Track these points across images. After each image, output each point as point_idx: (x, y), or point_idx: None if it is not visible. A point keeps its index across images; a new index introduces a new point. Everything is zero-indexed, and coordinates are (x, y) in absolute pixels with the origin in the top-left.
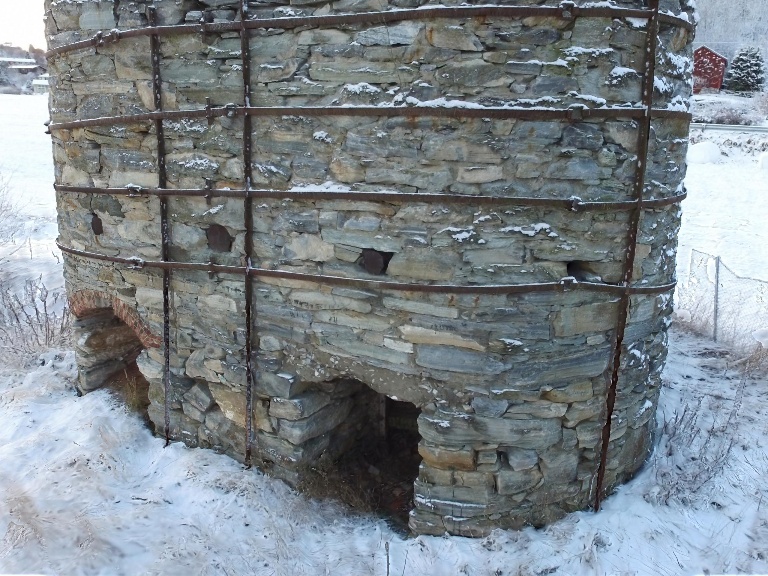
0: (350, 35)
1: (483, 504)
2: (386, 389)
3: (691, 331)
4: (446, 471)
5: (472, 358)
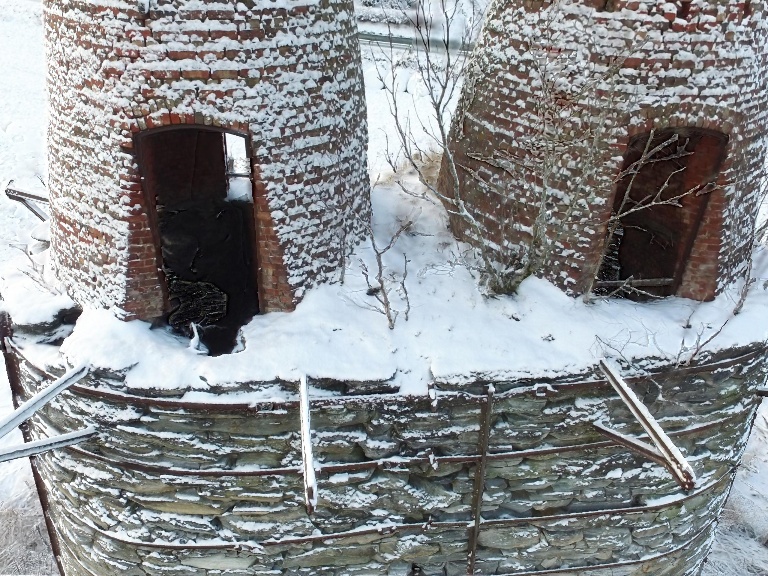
0: (576, 574)
1: None
2: None
3: None
4: None
5: None
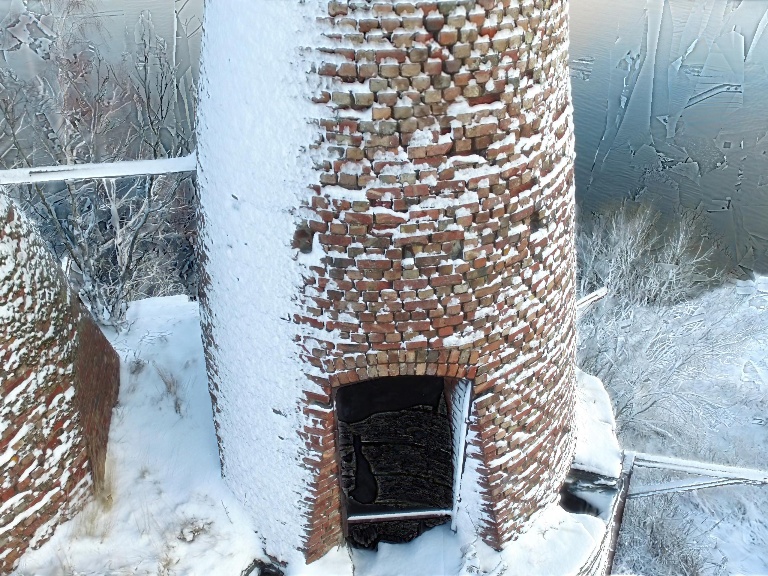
0: None
1: None
2: None
3: None
4: None
5: None
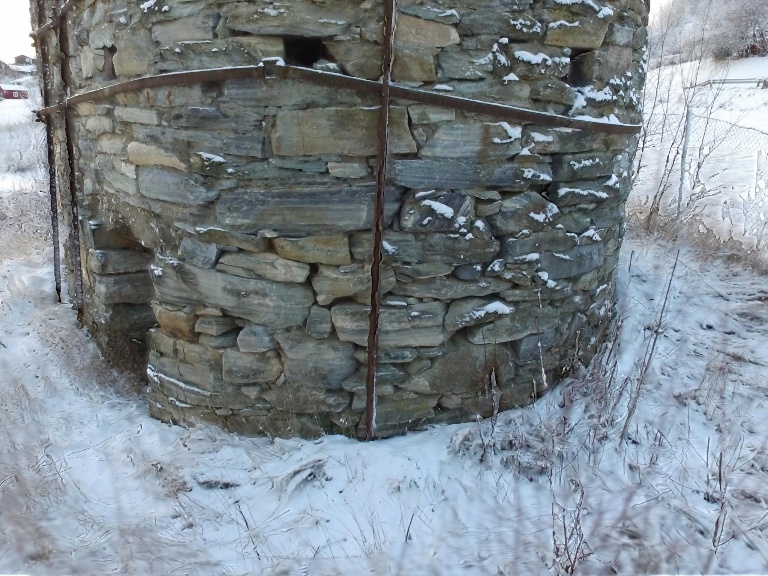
0: None
1: (209, 391)
2: (137, 232)
3: (753, 267)
4: (171, 338)
5: (174, 180)
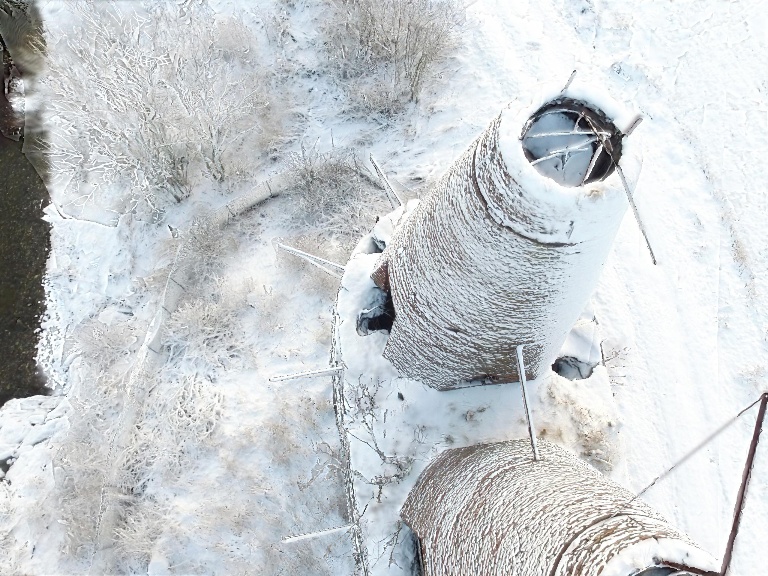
0: None
1: None
2: None
3: None
4: None
5: None
